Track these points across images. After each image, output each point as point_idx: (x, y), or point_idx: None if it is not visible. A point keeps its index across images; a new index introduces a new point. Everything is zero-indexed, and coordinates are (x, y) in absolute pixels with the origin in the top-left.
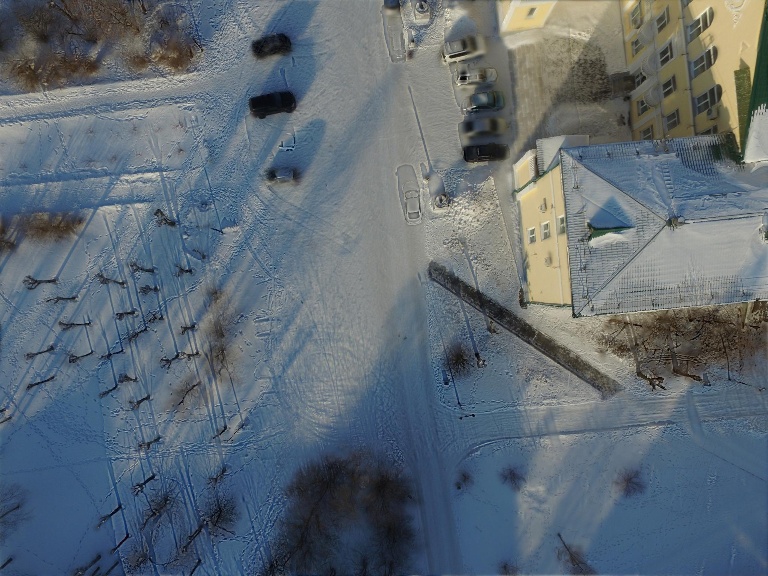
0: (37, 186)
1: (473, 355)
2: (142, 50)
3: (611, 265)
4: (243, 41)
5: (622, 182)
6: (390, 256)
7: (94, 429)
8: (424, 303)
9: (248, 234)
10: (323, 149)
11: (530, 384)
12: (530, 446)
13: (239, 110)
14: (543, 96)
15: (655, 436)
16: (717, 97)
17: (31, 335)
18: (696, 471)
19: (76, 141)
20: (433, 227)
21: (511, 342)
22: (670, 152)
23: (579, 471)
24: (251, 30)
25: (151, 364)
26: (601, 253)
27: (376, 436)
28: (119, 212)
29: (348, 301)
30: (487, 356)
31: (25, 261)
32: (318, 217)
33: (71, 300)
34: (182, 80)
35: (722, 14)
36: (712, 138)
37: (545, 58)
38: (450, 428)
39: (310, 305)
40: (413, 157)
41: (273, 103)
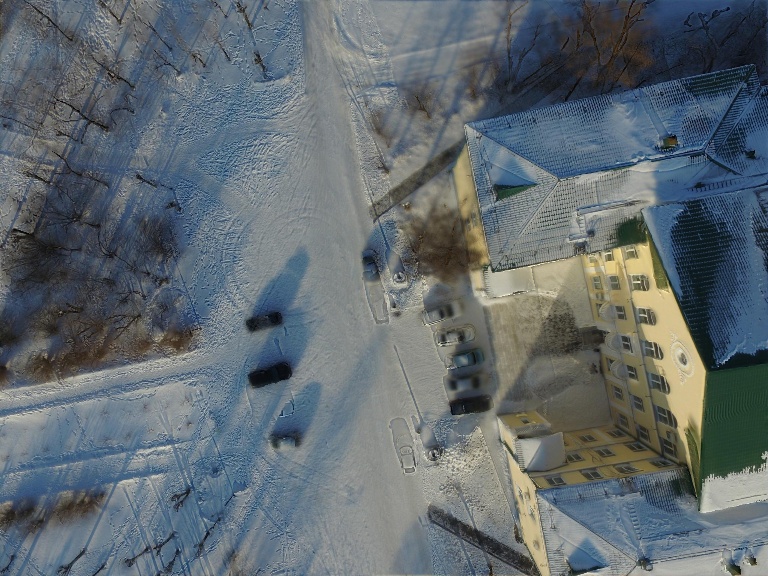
0: (60, 467)
1: None
2: (145, 333)
3: None
4: (237, 316)
5: (594, 524)
6: (391, 503)
7: None
8: (427, 544)
9: (258, 494)
10: (320, 410)
11: None
12: None
13: (239, 380)
14: (519, 351)
15: None
16: (674, 421)
17: None
18: None
19: (92, 423)
20: (429, 474)
21: (511, 575)
22: (635, 491)
23: None
24: (244, 305)
25: None
26: None
27: None
28: (137, 484)
29: (356, 548)
30: None
31: (55, 537)
32: (321, 473)
33: (101, 569)
34: (185, 358)
35: (670, 362)
36: (671, 473)
37: (518, 316)
38: None
39: (321, 554)
40: (404, 410)
41: (271, 379)
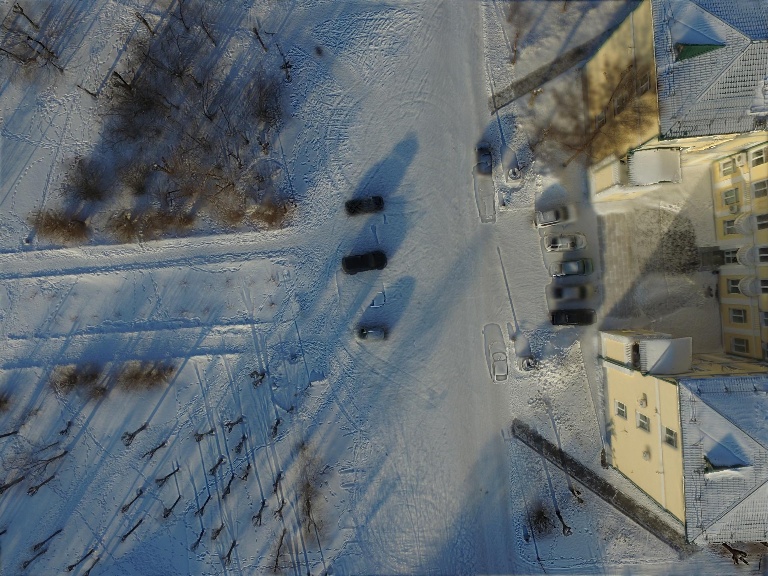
0: (131, 334)
1: (554, 512)
2: (237, 204)
3: (727, 499)
4: (336, 197)
5: (740, 419)
6: (474, 412)
7: (180, 572)
8: (507, 459)
9: (336, 387)
10: (412, 306)
11: (609, 543)
12: None
13: (330, 265)
14: (632, 265)
15: None
16: None
17: (121, 478)
18: None
19: (170, 291)
20: (518, 386)
21: (591, 501)
22: None
23: None
24: (344, 187)
25: (237, 511)
26: (717, 486)
27: None
28: (210, 362)
29: (432, 455)
30: (567, 514)
31: (117, 407)
32: (405, 372)
33: (161, 446)
34: (275, 235)
35: None
36: None
37: (635, 228)
38: None
39: (394, 457)
40: (500, 316)
41: (366, 264)
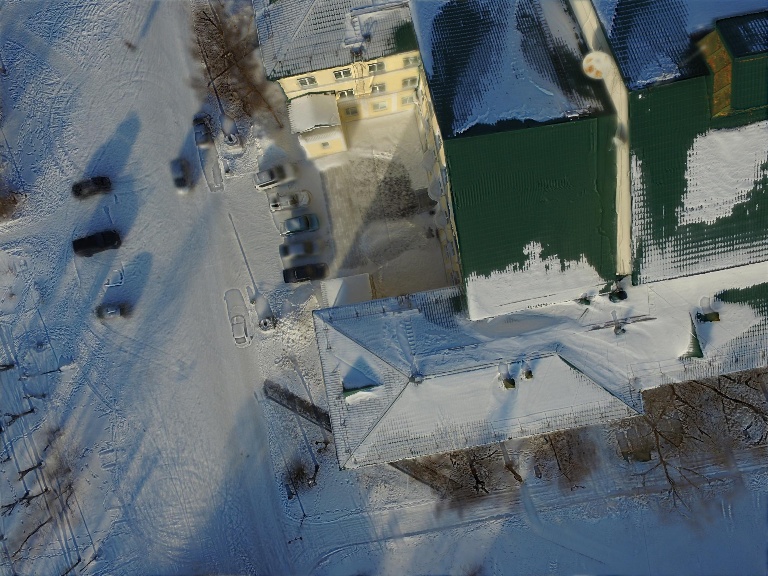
0: None
1: (313, 467)
2: None
3: (367, 420)
4: (65, 183)
5: (369, 341)
6: (226, 378)
7: None
8: (262, 421)
9: (86, 369)
10: (152, 281)
11: (371, 490)
12: (377, 550)
13: (67, 250)
14: (354, 215)
15: (495, 530)
16: None
17: None
18: (537, 560)
19: None
20: (264, 347)
21: None
22: (413, 308)
23: (426, 570)
24: (72, 172)
25: None
26: (357, 409)
27: (228, 554)
28: None
29: (189, 425)
30: (327, 467)
31: None
32: (153, 347)
33: None
34: (9, 226)
35: None
36: (453, 290)
37: (353, 179)
38: (299, 539)
39: (153, 432)
40: (239, 281)
41: (95, 245)
